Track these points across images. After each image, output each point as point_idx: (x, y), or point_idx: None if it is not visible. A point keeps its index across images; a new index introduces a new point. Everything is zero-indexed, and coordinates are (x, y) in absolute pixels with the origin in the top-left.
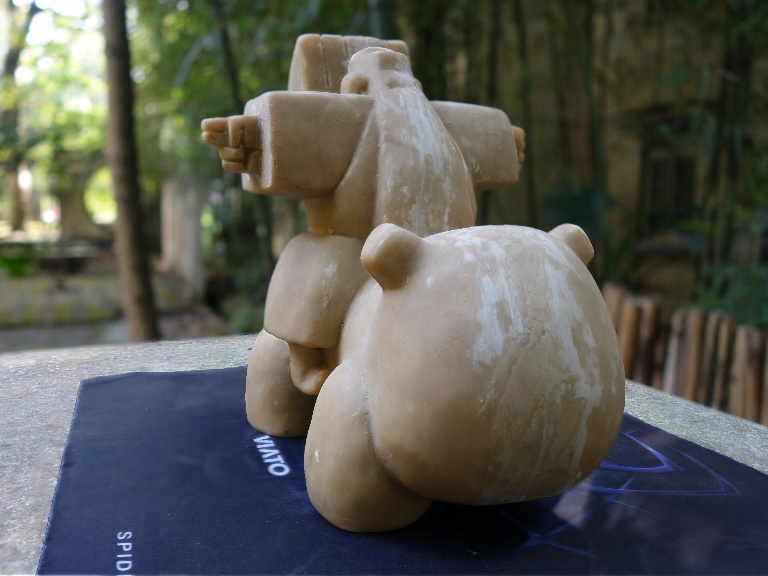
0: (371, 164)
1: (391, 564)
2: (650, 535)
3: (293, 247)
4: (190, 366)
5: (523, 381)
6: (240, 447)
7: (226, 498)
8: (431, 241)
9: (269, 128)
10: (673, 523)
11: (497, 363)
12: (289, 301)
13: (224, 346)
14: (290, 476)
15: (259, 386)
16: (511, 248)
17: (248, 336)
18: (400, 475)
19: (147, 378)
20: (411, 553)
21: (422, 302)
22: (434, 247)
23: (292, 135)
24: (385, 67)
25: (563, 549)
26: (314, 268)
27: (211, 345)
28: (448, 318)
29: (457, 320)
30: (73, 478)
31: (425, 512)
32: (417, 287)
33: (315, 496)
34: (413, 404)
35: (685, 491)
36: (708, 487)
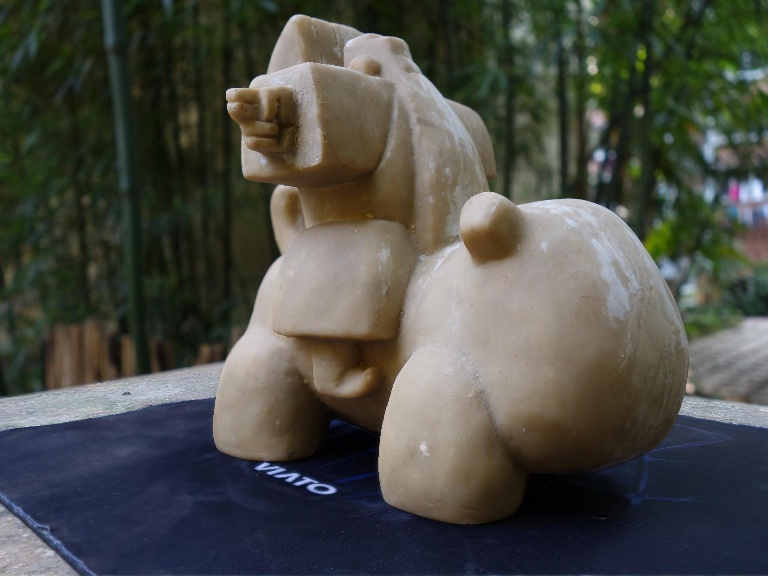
0: (407, 146)
1: (546, 543)
2: (713, 477)
3: (321, 236)
4: (71, 417)
5: (650, 334)
6: (249, 477)
7: (302, 523)
8: (525, 210)
9: (315, 100)
10: (717, 466)
11: (629, 318)
12: (336, 292)
13: (88, 395)
14: (343, 492)
15: (253, 406)
16: (597, 215)
17: (106, 383)
18: (530, 450)
19: (37, 432)
20: (551, 530)
21: (543, 266)
22: (533, 215)
23: (338, 109)
24: (397, 52)
25: (666, 500)
26: (365, 254)
27: (70, 396)
28: (576, 279)
29: (585, 280)
30: (80, 541)
31: (524, 494)
32: (532, 253)
33: (421, 496)
34: (554, 369)
35: (692, 443)
36: (703, 438)
